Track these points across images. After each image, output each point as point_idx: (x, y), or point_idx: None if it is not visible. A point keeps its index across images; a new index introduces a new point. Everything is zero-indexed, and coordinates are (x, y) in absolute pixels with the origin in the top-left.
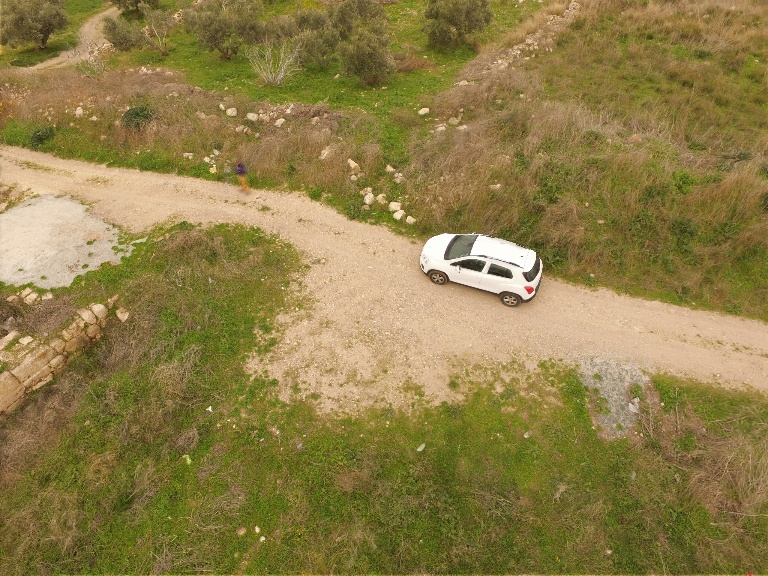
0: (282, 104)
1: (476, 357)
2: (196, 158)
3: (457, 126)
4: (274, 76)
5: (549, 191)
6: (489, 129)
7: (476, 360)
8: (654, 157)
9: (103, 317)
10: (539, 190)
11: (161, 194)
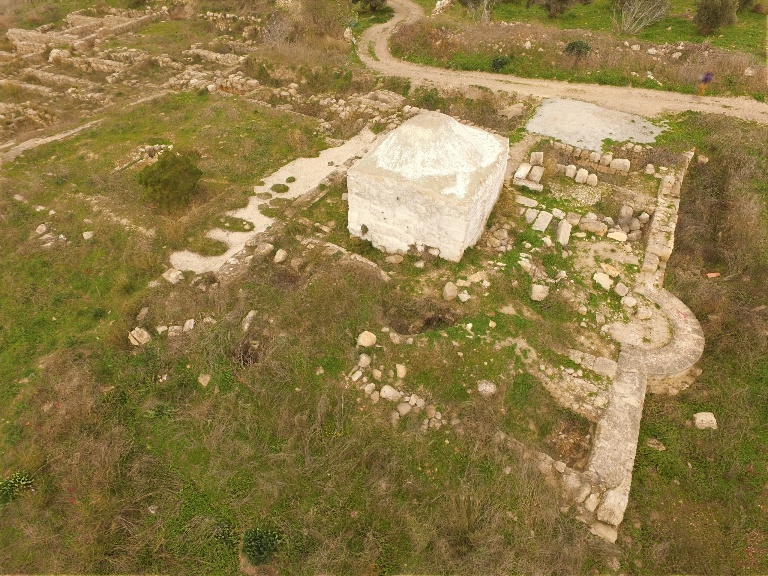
0: (670, 43)
1: None
2: (641, 76)
3: None
4: (629, 26)
5: None
6: None
7: None
8: None
9: None
10: None
11: (636, 98)
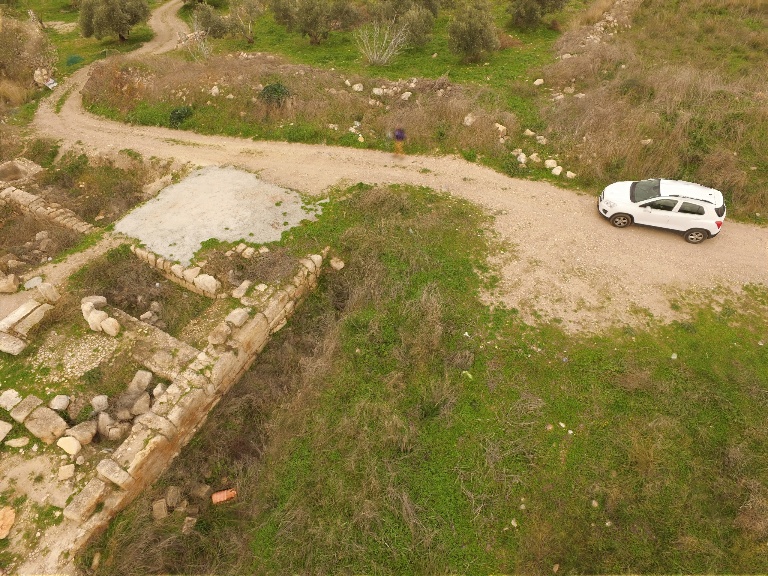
0: (403, 79)
1: (684, 284)
2: (341, 129)
3: (573, 95)
4: (379, 56)
5: (699, 143)
6: (612, 94)
7: (685, 287)
8: None
9: (319, 267)
10: (690, 143)
11: (319, 162)
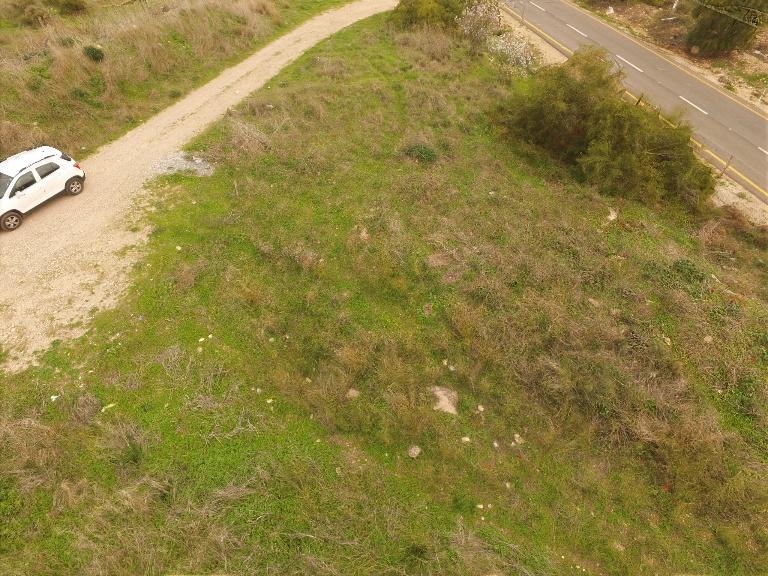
0: None
1: (117, 216)
2: None
3: None
4: None
5: None
6: None
7: (120, 216)
8: (1, 66)
9: None
10: None
11: None
